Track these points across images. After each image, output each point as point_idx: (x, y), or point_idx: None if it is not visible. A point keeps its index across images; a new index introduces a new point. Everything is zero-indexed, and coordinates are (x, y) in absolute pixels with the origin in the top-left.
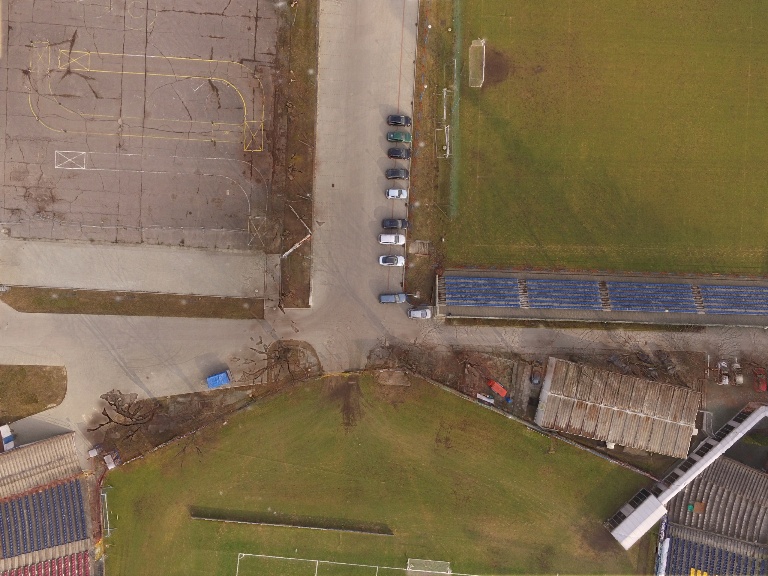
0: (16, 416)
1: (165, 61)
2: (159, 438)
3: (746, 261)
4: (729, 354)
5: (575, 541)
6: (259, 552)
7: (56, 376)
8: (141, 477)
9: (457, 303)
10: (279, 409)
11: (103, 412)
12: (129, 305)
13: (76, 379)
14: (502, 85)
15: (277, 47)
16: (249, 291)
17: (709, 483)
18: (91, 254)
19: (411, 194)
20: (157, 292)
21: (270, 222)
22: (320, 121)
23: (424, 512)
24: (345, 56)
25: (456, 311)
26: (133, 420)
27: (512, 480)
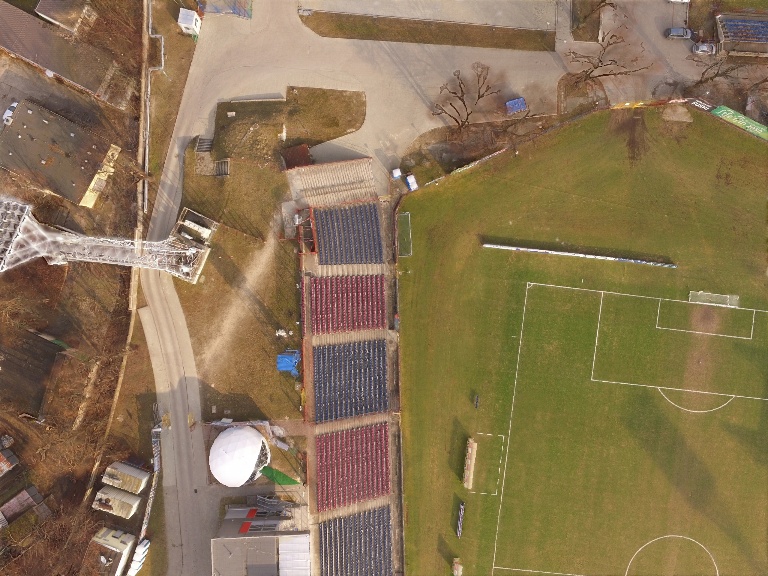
0: (316, 140)
1: None
2: (452, 167)
3: None
4: None
5: None
6: (547, 281)
7: (356, 101)
8: (434, 205)
9: (741, 39)
10: (568, 141)
11: (436, 106)
12: (426, 34)
13: (375, 105)
14: None
15: None
16: (541, 23)
17: None
18: None
19: None
20: (453, 21)
21: None
22: None
23: (705, 246)
24: None
25: (740, 47)
26: (428, 148)
27: None
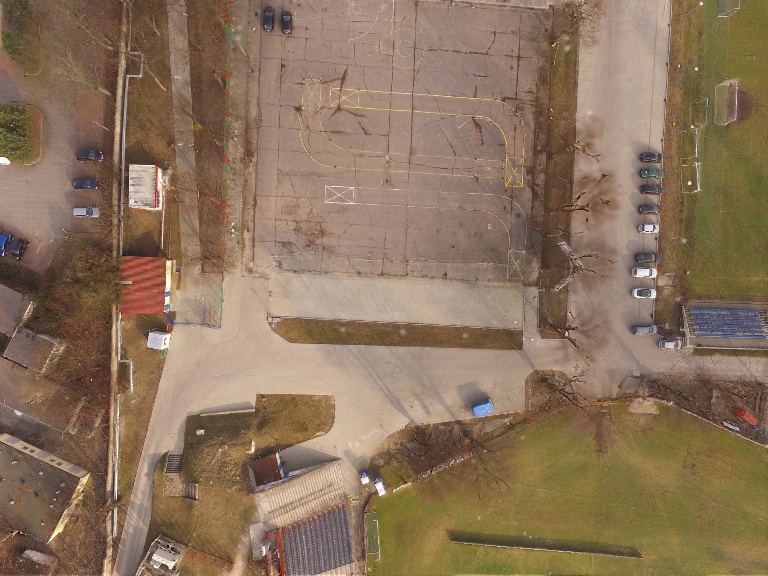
0: (286, 444)
1: (431, 99)
2: (421, 465)
3: None
4: None
5: None
6: (515, 575)
7: (325, 405)
8: (403, 503)
9: (707, 334)
10: (535, 437)
11: (401, 443)
12: (394, 336)
13: (344, 408)
14: (746, 123)
15: (537, 86)
16: (508, 322)
17: None
18: (358, 286)
19: (661, 228)
20: (421, 323)
21: (529, 255)
22: (575, 157)
23: (671, 536)
24: (599, 94)
25: (705, 342)
26: (396, 447)
27: (754, 505)
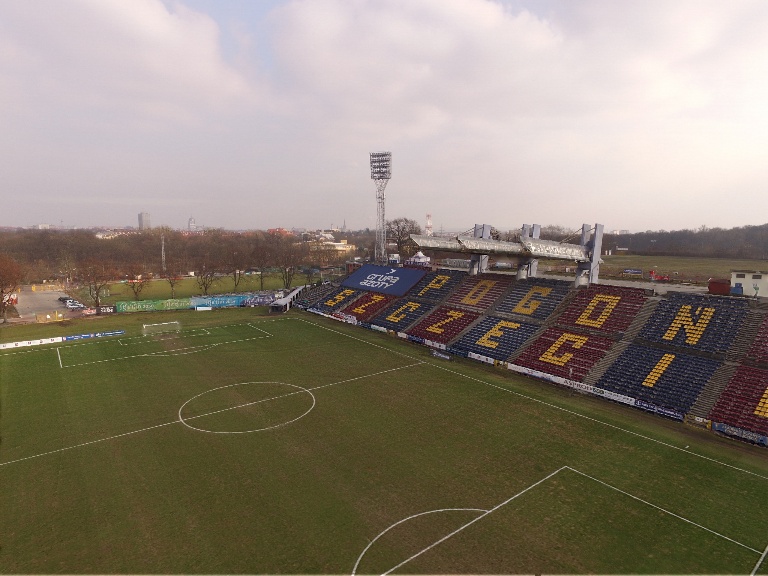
0: None
1: None
2: None
3: None
4: None
5: None
6: None
7: None
8: None
9: None
10: None
11: None
12: None
13: None
14: None
15: None
16: None
17: None
18: None
19: None
20: None
21: None
22: None
23: None
24: None
25: None
26: None
27: None
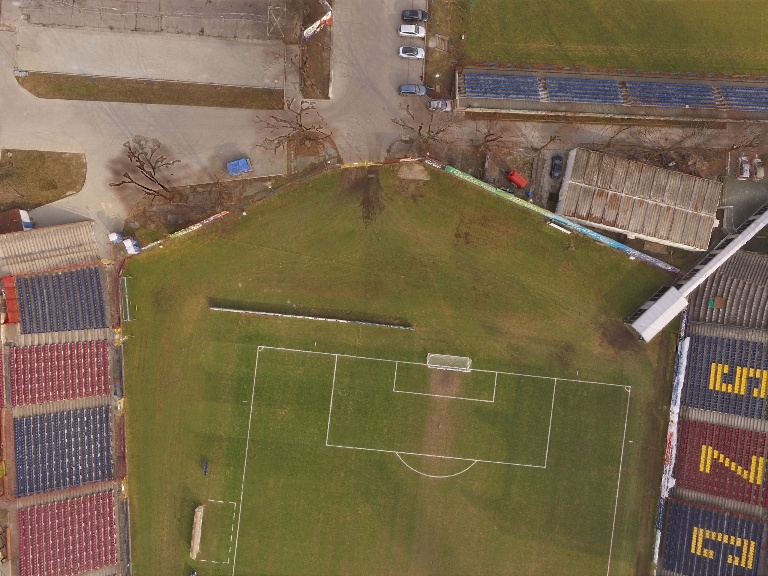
0: (35, 203)
1: None
2: (178, 228)
3: (766, 63)
4: (750, 150)
5: (595, 339)
6: (278, 345)
7: (75, 163)
8: (160, 268)
9: (477, 95)
10: (299, 201)
11: (125, 174)
12: (148, 93)
13: (95, 167)
14: None
15: None
16: (269, 81)
17: (730, 278)
18: (110, 42)
19: None
20: (177, 80)
21: (290, 12)
22: None
23: (444, 307)
24: None
25: (476, 103)
26: (152, 210)
27: (532, 276)
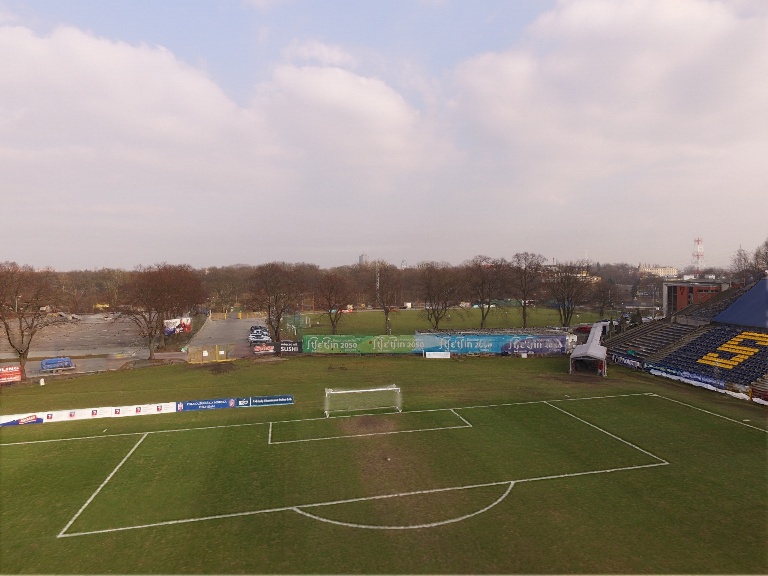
0: None
1: None
2: None
3: None
4: None
5: (553, 382)
6: (18, 440)
7: None
8: None
9: None
10: None
11: None
12: None
13: None
14: None
15: None
16: None
17: None
18: None
19: None
20: None
21: None
22: (202, 332)
23: (334, 390)
24: (221, 327)
25: None
26: None
27: None
